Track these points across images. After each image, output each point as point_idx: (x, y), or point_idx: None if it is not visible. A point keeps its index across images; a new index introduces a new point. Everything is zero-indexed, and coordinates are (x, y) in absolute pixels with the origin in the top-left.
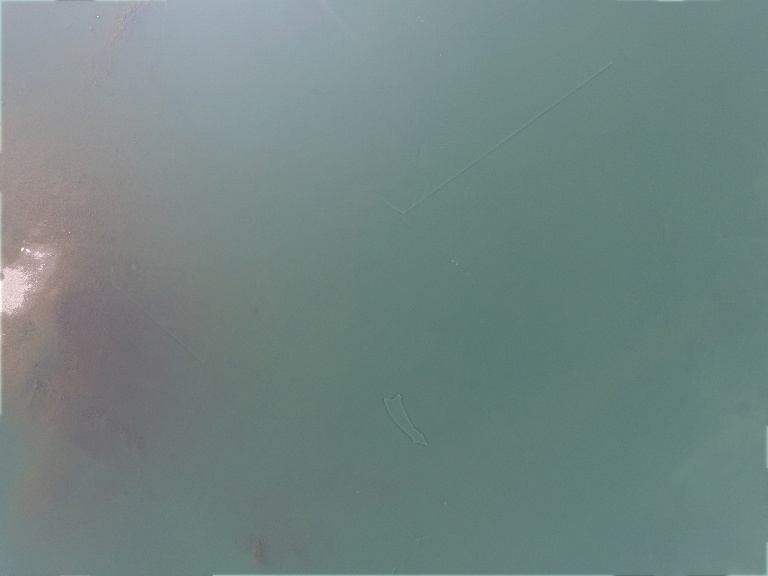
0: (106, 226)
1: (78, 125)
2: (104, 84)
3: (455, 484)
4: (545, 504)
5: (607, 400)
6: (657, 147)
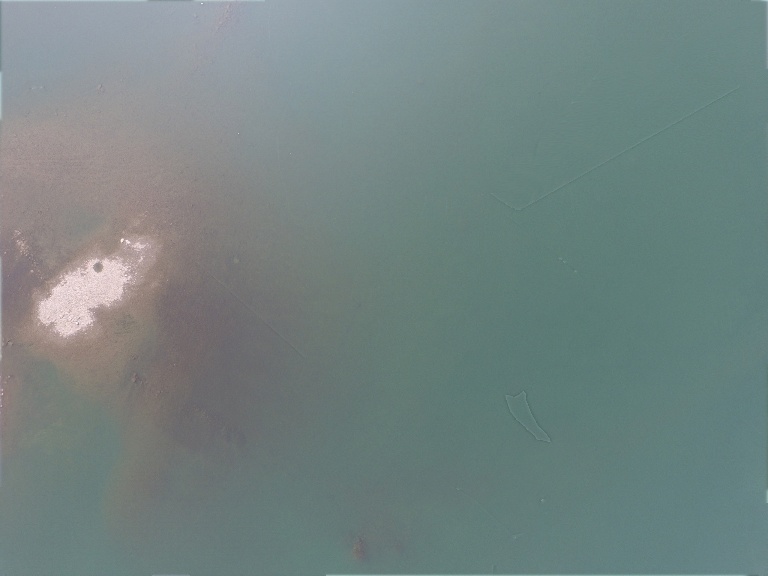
0: (208, 218)
1: (180, 114)
2: (208, 73)
3: (553, 481)
4: (646, 502)
5: (710, 399)
6: (762, 148)
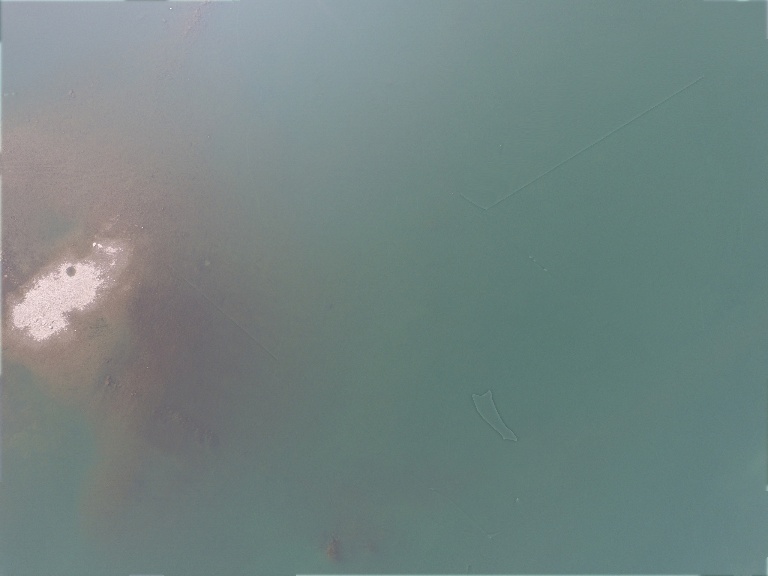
0: (179, 221)
1: (151, 119)
2: (177, 77)
3: (527, 481)
4: (620, 500)
5: (683, 396)
6: (733, 144)
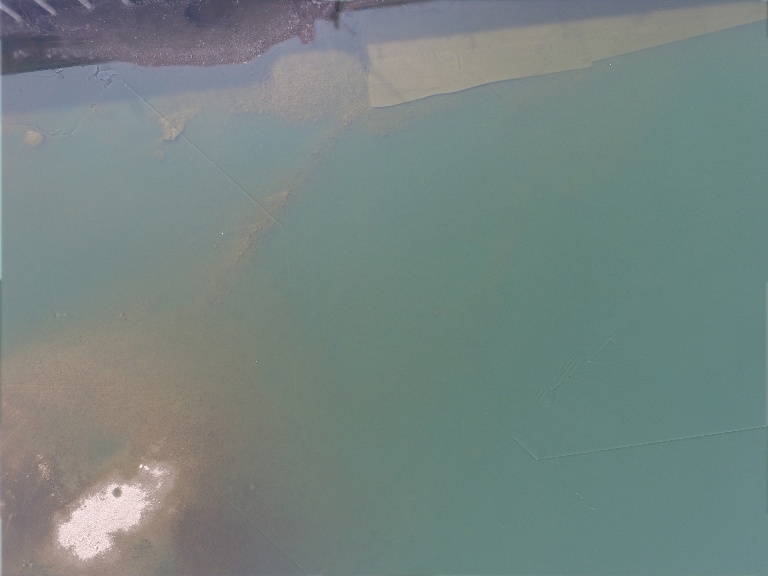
0: (225, 445)
1: (200, 342)
2: (227, 302)
3: None
4: None
5: None
6: None
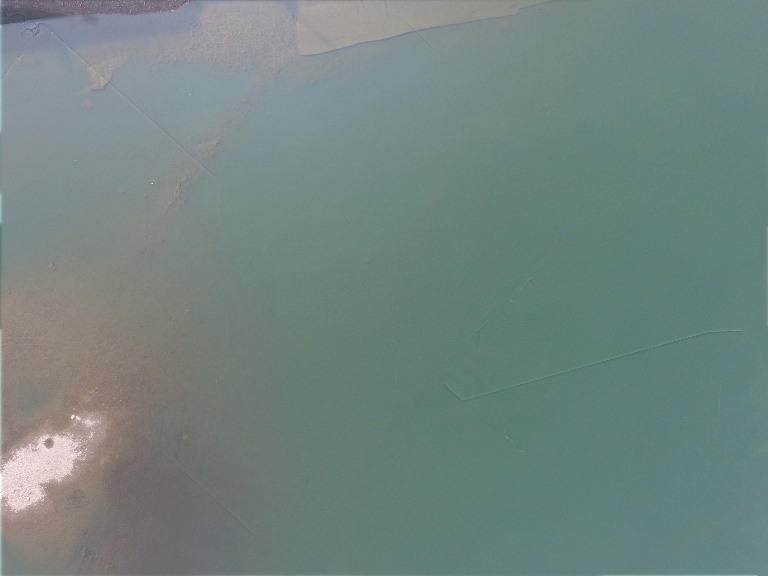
0: (158, 394)
1: (131, 292)
2: (158, 251)
3: None
4: None
5: None
6: None
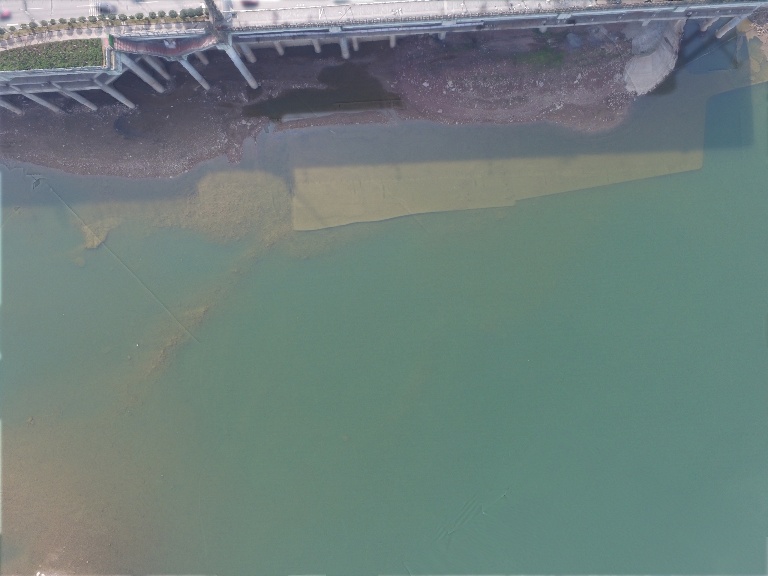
0: (125, 558)
1: (107, 453)
2: (137, 413)
3: None
4: None
5: None
6: None
